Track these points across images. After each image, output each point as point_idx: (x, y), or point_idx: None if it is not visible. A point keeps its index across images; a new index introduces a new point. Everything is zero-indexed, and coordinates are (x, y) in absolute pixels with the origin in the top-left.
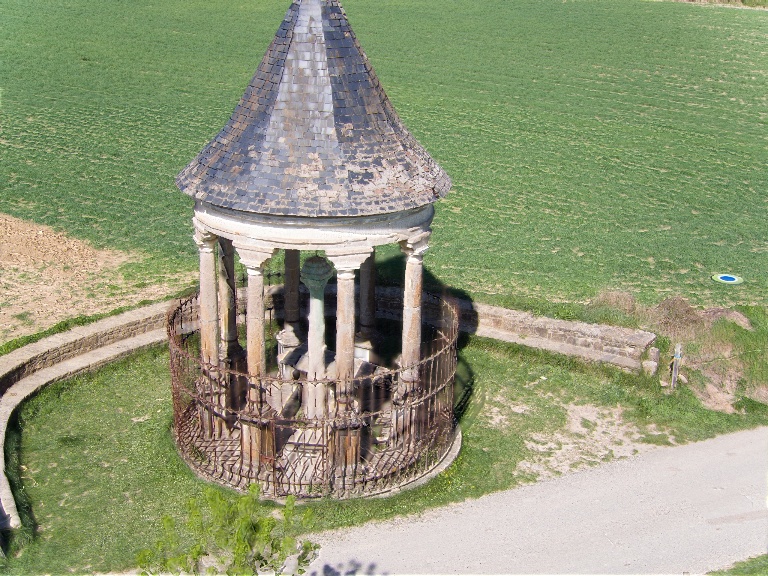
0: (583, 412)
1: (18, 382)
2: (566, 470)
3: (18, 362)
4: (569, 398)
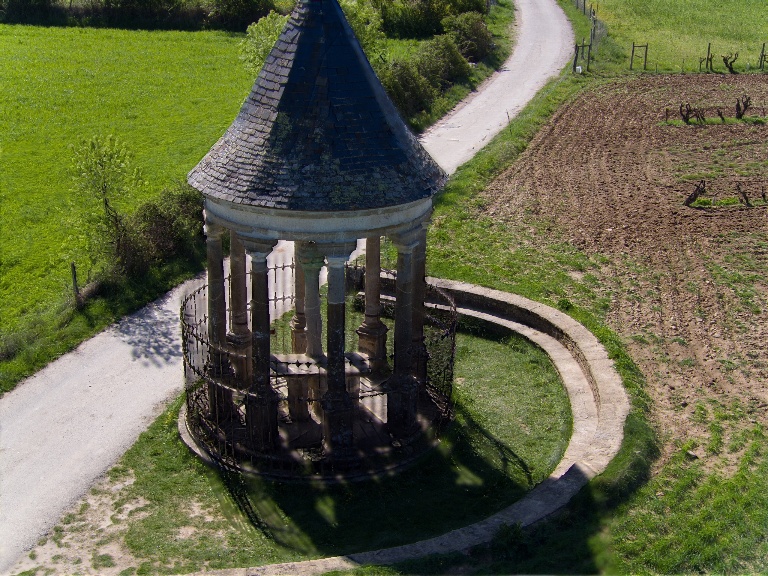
0: (119, 569)
1: (556, 339)
2: (91, 498)
3: (563, 327)
4: (145, 569)
